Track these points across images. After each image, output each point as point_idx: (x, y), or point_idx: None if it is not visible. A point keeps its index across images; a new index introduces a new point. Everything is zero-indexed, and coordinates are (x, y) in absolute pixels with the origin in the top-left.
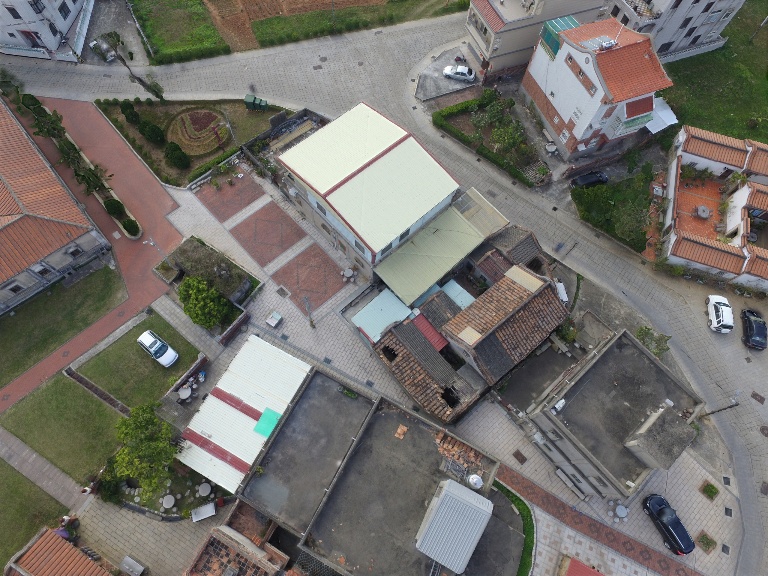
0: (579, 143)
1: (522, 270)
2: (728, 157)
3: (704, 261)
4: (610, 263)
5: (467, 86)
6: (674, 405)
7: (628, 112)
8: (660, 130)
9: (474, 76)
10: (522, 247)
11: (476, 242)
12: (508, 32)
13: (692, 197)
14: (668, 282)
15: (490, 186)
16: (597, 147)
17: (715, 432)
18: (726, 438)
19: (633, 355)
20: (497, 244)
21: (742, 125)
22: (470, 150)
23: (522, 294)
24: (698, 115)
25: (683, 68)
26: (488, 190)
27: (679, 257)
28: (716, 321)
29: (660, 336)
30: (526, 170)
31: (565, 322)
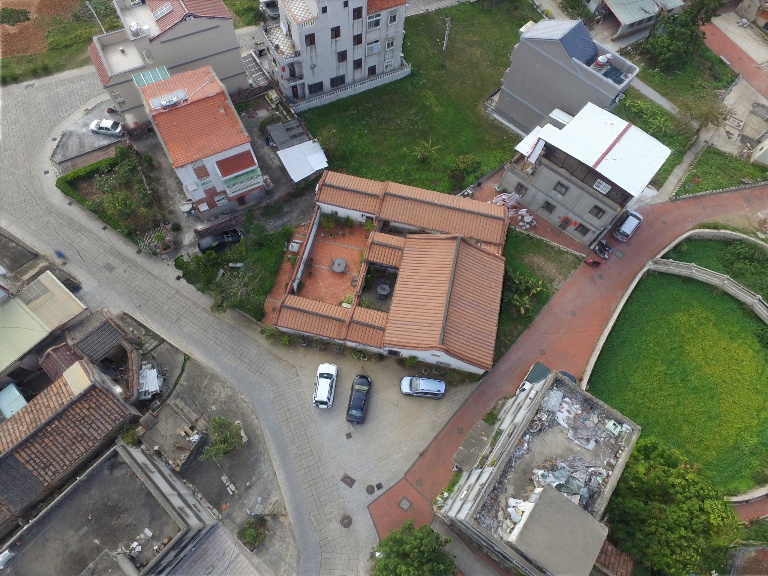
0: (198, 203)
1: (80, 367)
2: (361, 204)
3: (306, 329)
4: (225, 336)
5: (112, 142)
6: (153, 535)
7: (222, 170)
8: (304, 177)
9: (121, 130)
10: (96, 337)
11: (37, 338)
12: (122, 84)
13: (336, 248)
14: (284, 352)
15: (110, 258)
16: (236, 202)
17: (289, 530)
18: (299, 536)
19: (124, 476)
20: (69, 336)
21: (412, 160)
22: (97, 217)
23: (65, 399)
24: (367, 153)
25: (365, 100)
26: (106, 263)
27: (281, 327)
28: (314, 396)
29: (232, 427)
30: (143, 238)
31: (124, 424)
